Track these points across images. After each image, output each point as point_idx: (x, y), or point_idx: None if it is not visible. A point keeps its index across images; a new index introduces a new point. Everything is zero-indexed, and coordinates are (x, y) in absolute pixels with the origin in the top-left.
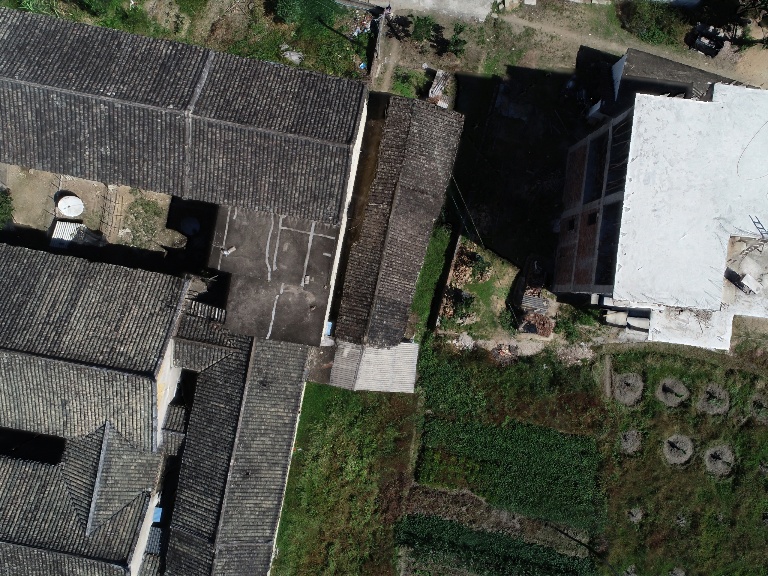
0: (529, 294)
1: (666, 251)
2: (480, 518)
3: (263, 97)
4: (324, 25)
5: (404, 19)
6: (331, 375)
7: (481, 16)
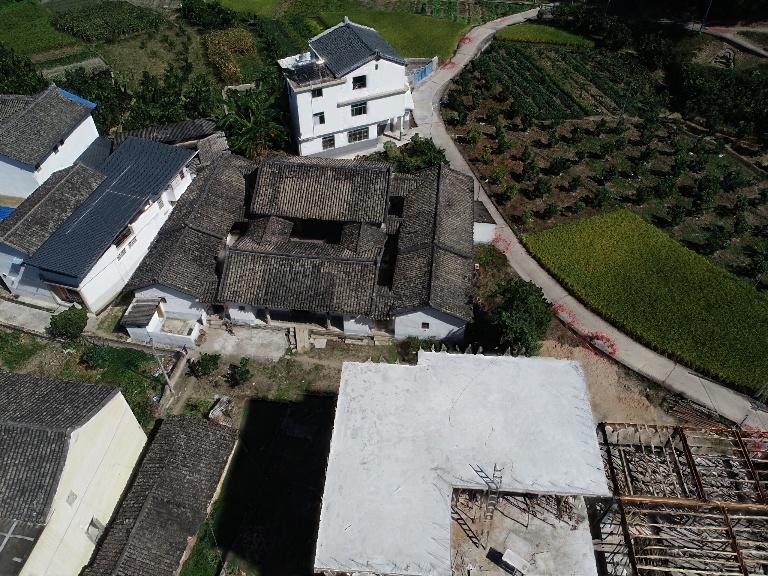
0: None
1: (378, 506)
2: None
3: (7, 398)
4: (129, 369)
5: None
6: None
7: (275, 358)
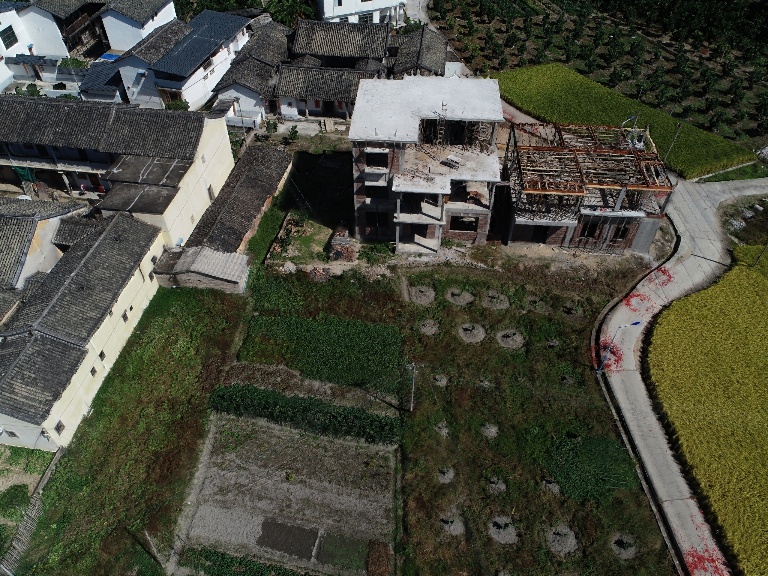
0: (337, 237)
1: (381, 122)
2: (293, 386)
3: None
4: None
5: (266, 136)
6: (175, 267)
7: (312, 134)
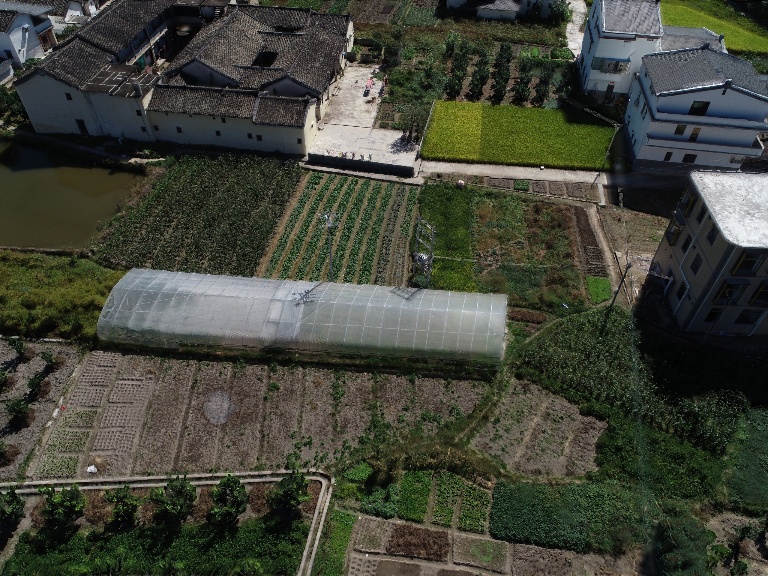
0: None
1: None
2: None
3: None
4: None
5: None
6: None
7: None
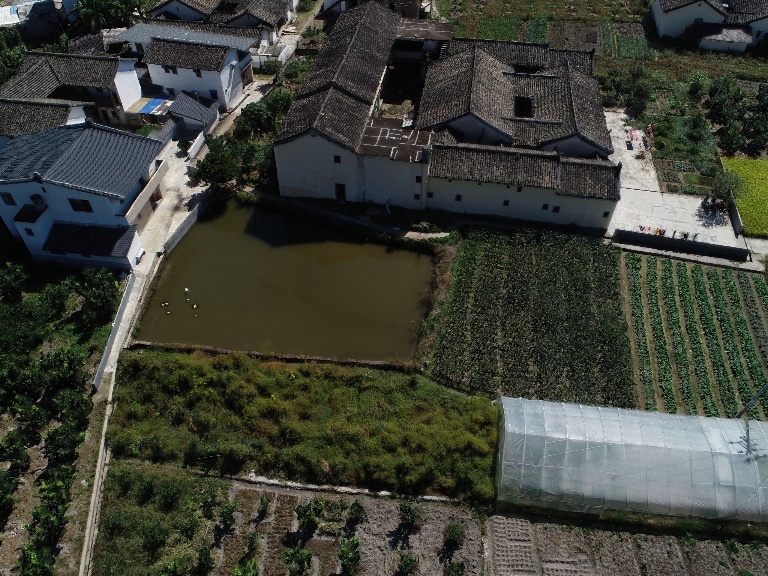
0: None
1: None
2: None
3: None
4: None
5: None
6: None
7: None
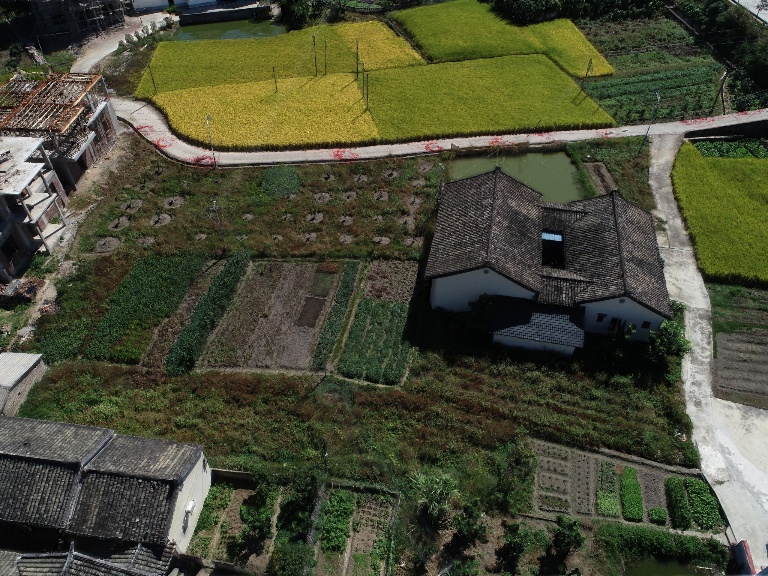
0: (3, 292)
1: None
2: None
3: None
4: None
5: None
6: None
7: None
